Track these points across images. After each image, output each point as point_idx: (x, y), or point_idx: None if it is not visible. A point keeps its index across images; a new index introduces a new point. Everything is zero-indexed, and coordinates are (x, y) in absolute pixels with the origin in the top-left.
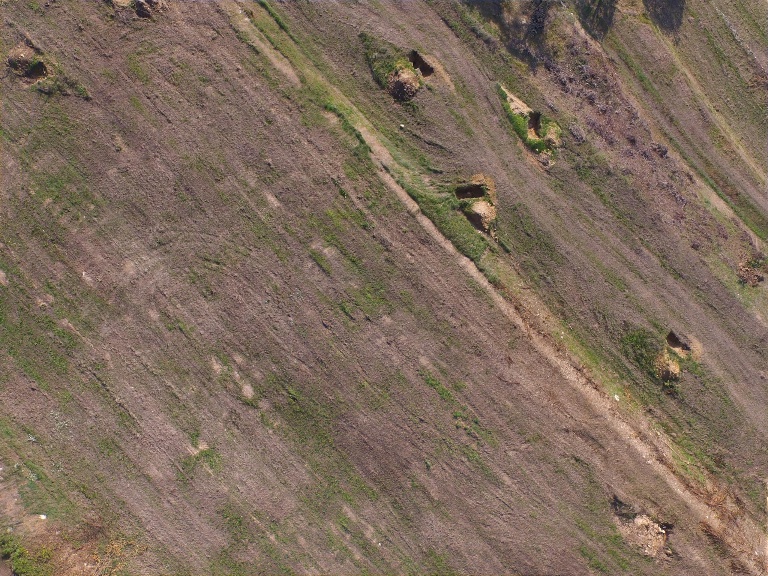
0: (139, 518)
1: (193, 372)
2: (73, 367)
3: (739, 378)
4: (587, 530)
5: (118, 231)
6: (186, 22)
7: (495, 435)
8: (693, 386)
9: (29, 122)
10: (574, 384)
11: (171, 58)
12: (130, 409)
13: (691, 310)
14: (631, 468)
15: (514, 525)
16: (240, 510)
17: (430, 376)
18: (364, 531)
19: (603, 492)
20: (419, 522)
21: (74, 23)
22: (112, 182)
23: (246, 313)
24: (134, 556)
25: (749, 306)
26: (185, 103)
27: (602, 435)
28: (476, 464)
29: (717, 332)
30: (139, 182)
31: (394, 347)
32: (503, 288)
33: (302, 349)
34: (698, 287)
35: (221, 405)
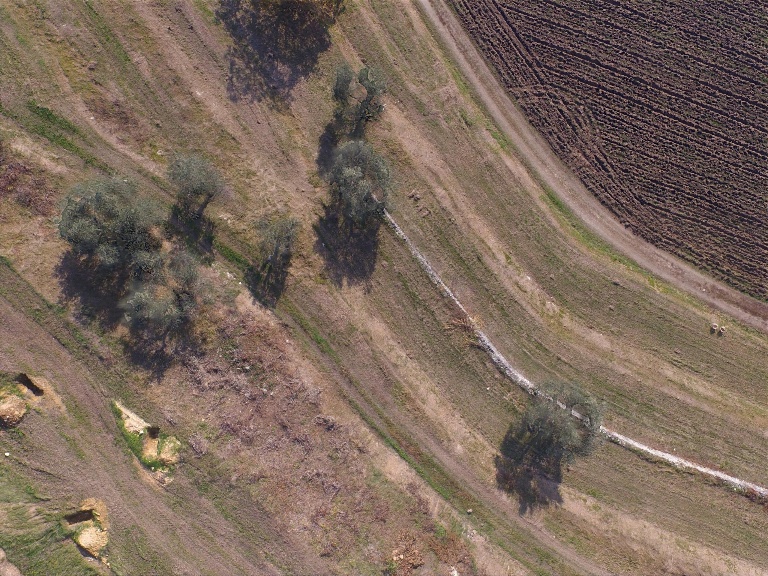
0: None
1: None
2: None
3: None
4: None
5: None
6: None
7: None
8: None
9: None
10: None
11: None
12: None
13: None
14: None
15: None
16: None
17: None
18: None
19: None
20: None
21: None
22: None
23: None
24: None
25: None
26: None
27: None
28: None
29: None
30: None
31: None
32: None
33: None
34: None
35: None
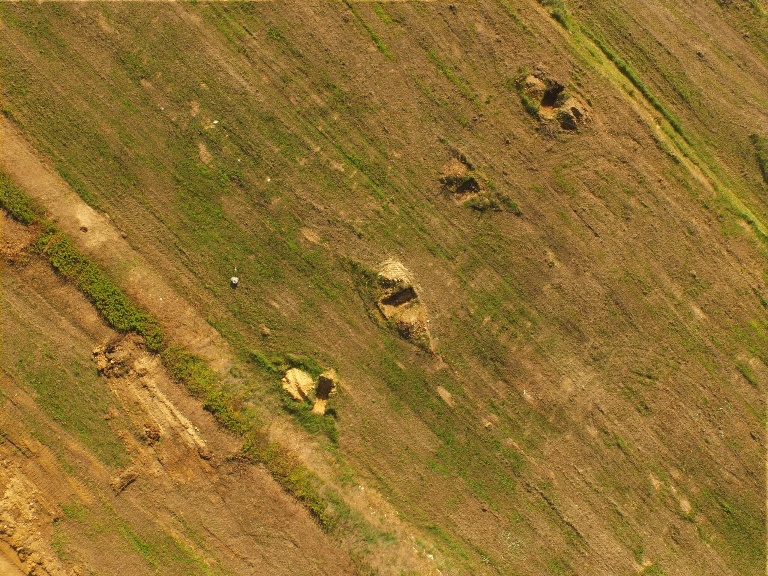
0: None
1: (633, 488)
2: (520, 487)
3: None
4: None
5: (555, 348)
6: (607, 133)
7: None
8: None
9: (464, 239)
10: None
11: (597, 171)
12: (578, 528)
13: None
14: None
15: None
16: None
17: None
18: None
19: None
20: None
21: (501, 137)
22: (547, 298)
23: (680, 427)
24: None
25: None
26: (611, 216)
27: None
28: None
29: None
30: (572, 298)
31: None
32: None
33: (733, 462)
34: None
35: (661, 521)
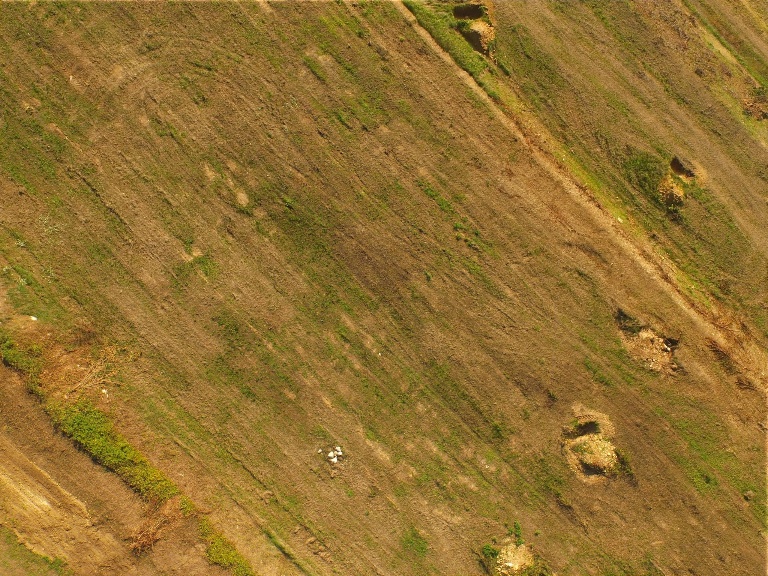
0: (133, 323)
1: (186, 179)
2: (62, 172)
3: (744, 205)
4: (591, 344)
5: (106, 35)
6: None
7: (496, 248)
8: (697, 212)
9: None
10: (576, 199)
11: None
12: (121, 214)
13: (695, 136)
14: (635, 283)
15: (517, 338)
16: (236, 318)
17: (429, 187)
18: (363, 341)
19: (607, 306)
20: (420, 333)
21: None
22: None
23: (239, 120)
24: (128, 362)
25: (754, 134)
26: None
27: (605, 249)
28: (477, 276)
29: (722, 158)
30: None
31: (392, 157)
32: (503, 105)
33: (297, 157)
34: (702, 112)
35: (215, 212)
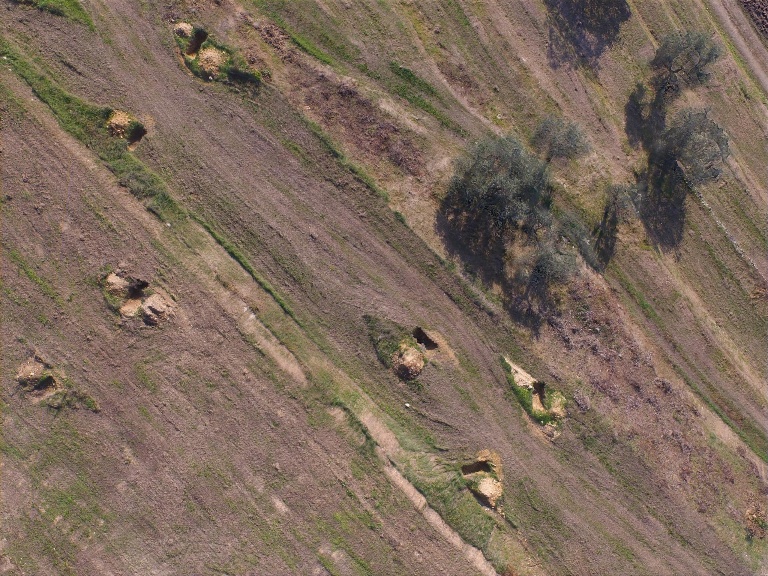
0: None
1: None
2: None
3: None
4: None
5: (128, 546)
6: (193, 327)
7: None
8: None
9: (39, 438)
10: None
11: (178, 366)
12: None
13: None
14: None
15: None
16: None
17: None
18: None
19: None
20: None
21: (82, 334)
22: (121, 496)
23: None
24: None
25: (758, 567)
26: (193, 410)
27: None
28: None
29: None
30: (148, 494)
31: None
32: (511, 574)
33: None
34: (706, 554)
35: None
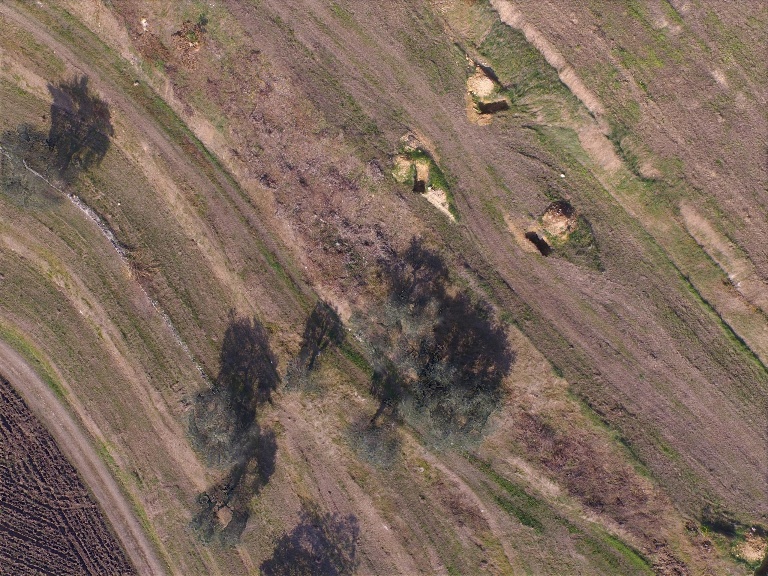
0: None
1: None
2: None
3: None
4: None
5: None
6: None
7: None
8: None
9: None
10: None
11: None
12: None
13: None
14: None
15: None
16: None
17: None
18: None
19: None
20: None
21: None
22: None
23: None
24: None
25: None
26: None
27: None
28: None
29: None
30: None
31: None
32: None
33: None
34: (256, 8)
35: None
